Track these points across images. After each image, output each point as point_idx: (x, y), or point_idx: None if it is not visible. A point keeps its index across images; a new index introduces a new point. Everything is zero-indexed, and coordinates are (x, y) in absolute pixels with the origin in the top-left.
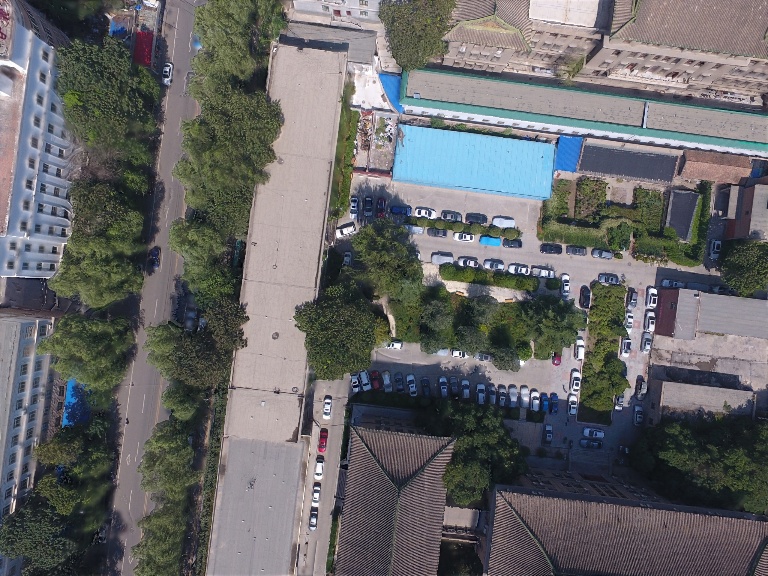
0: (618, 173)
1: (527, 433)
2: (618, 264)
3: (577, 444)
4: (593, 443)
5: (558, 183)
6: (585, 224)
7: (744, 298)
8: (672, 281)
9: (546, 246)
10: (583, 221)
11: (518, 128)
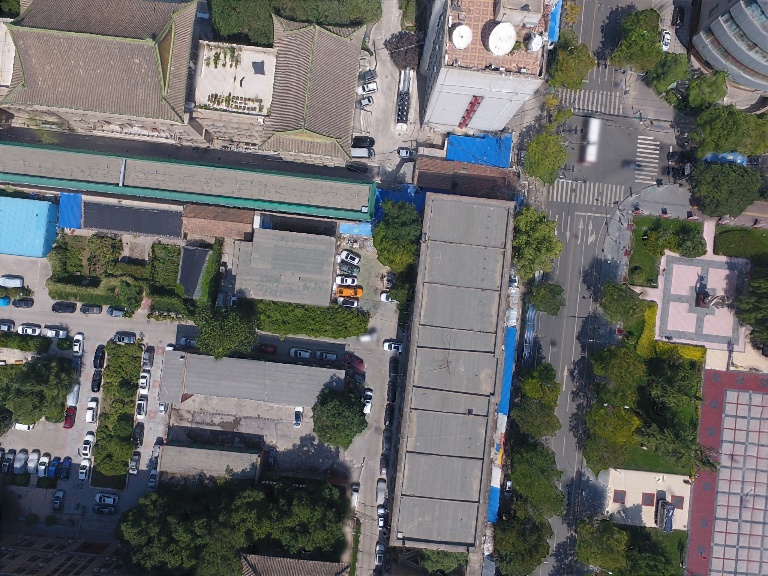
0: (125, 229)
1: (37, 500)
2: (136, 322)
3: (91, 510)
4: (102, 509)
5: (72, 240)
6: (97, 282)
7: (234, 359)
8: (187, 339)
9: (56, 305)
10: (97, 278)
11: (21, 185)
